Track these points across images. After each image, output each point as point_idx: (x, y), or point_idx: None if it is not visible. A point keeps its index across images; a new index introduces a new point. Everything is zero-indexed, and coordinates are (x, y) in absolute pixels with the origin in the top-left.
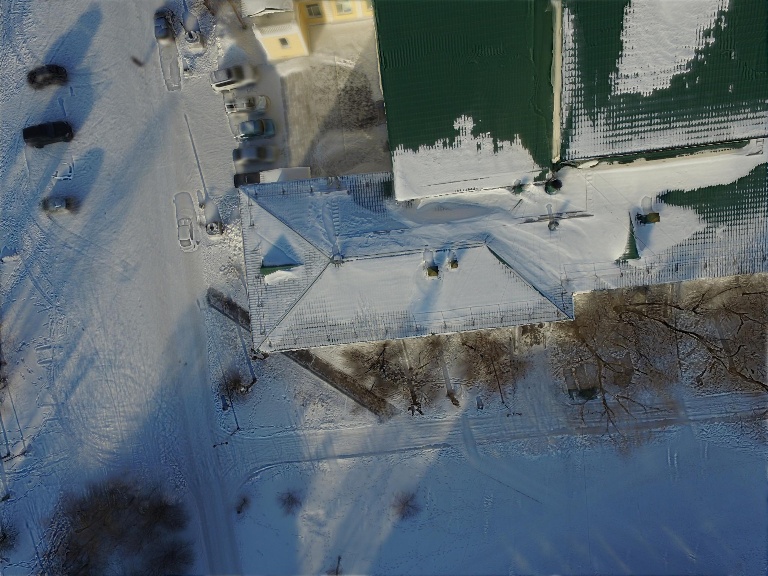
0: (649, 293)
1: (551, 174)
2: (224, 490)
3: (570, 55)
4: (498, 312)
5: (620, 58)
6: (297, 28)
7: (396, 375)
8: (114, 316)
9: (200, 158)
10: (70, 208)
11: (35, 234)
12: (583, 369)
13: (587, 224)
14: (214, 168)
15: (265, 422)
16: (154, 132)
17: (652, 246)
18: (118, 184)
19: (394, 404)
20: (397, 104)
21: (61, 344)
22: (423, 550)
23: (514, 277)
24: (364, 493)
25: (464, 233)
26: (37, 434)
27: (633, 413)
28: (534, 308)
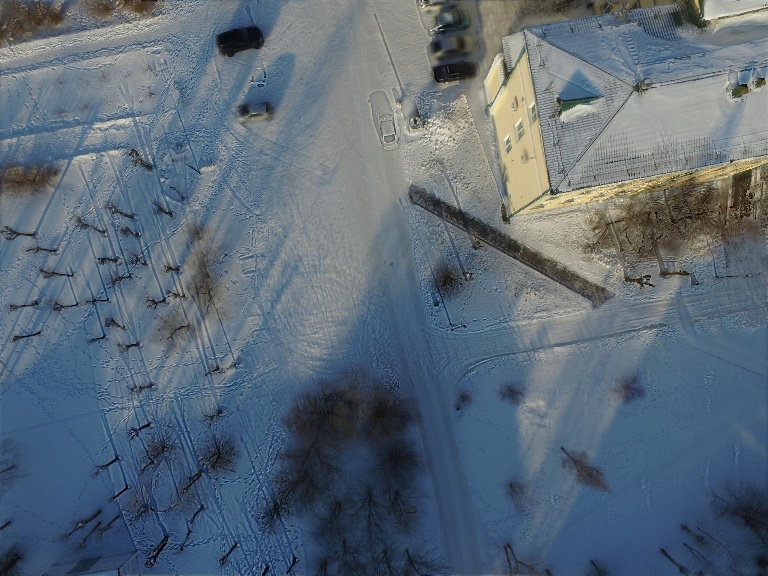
0: None
1: None
2: (439, 389)
3: None
4: None
5: None
6: None
7: (608, 257)
8: (316, 221)
9: (393, 56)
10: (264, 115)
11: (230, 143)
12: None
13: None
14: (408, 64)
15: (478, 316)
16: (344, 33)
17: None
18: (312, 87)
19: (607, 287)
20: None
21: (264, 253)
22: (647, 433)
23: None
24: (582, 380)
25: (767, 51)
26: (245, 346)
27: None
28: None
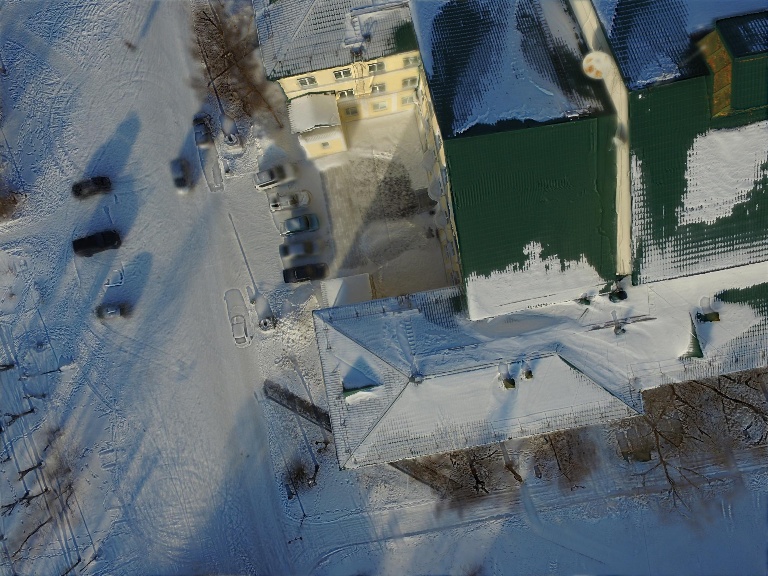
0: None
1: (615, 286)
2: None
3: (639, 195)
4: (571, 414)
5: (685, 194)
6: (341, 134)
7: None
8: (174, 415)
9: (247, 255)
10: (123, 313)
11: (90, 341)
12: (634, 431)
13: (650, 326)
14: (262, 264)
15: (330, 507)
16: (200, 233)
17: (712, 341)
18: (168, 286)
19: (455, 479)
20: (470, 237)
21: (123, 447)
22: None
23: (585, 381)
24: (432, 568)
25: (535, 344)
26: (106, 537)
27: None
28: (605, 407)
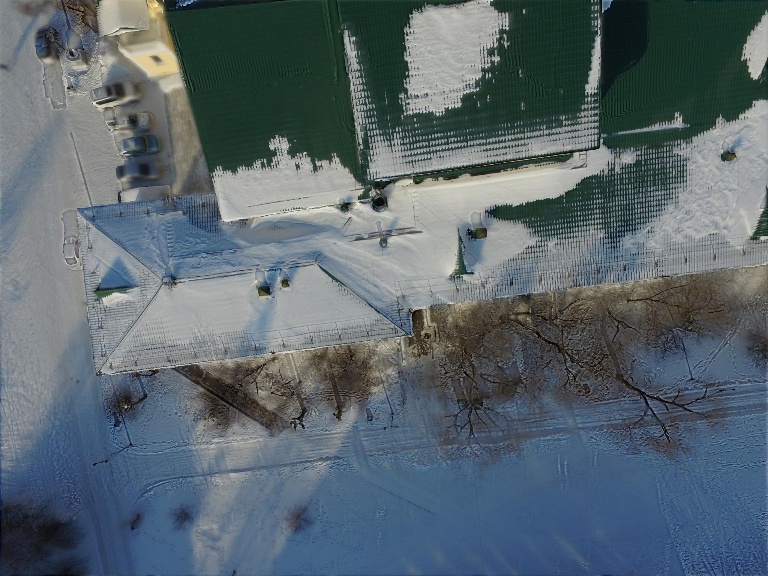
0: (532, 302)
1: (374, 192)
2: (119, 506)
3: (357, 76)
4: (335, 330)
5: (407, 78)
6: (163, 45)
7: (285, 388)
8: (5, 335)
9: (86, 175)
10: None
11: None
12: None
13: (418, 240)
14: (100, 185)
15: (157, 438)
16: (41, 150)
17: (485, 261)
18: (6, 203)
19: (284, 417)
20: (209, 126)
21: None
22: (317, 563)
23: (348, 295)
24: (257, 507)
25: (295, 252)
26: None
27: None
28: (371, 325)
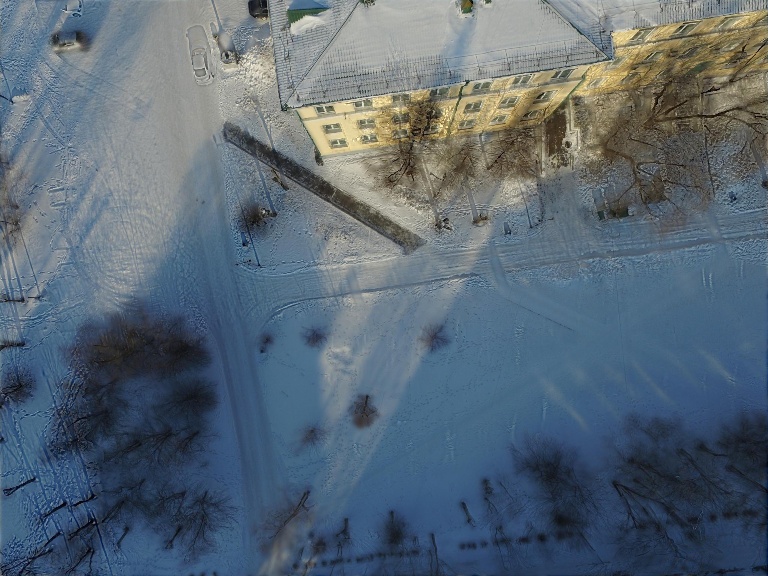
0: None
1: None
2: (246, 331)
3: None
4: (534, 54)
5: None
6: None
7: (420, 203)
8: (128, 155)
9: None
10: (80, 46)
11: (45, 73)
12: (612, 190)
13: None
14: None
15: (287, 258)
16: None
17: None
18: (129, 19)
19: (419, 234)
20: None
21: (74, 186)
22: (453, 384)
23: (550, 13)
24: (391, 328)
25: None
26: (52, 279)
27: (665, 233)
28: (572, 48)
